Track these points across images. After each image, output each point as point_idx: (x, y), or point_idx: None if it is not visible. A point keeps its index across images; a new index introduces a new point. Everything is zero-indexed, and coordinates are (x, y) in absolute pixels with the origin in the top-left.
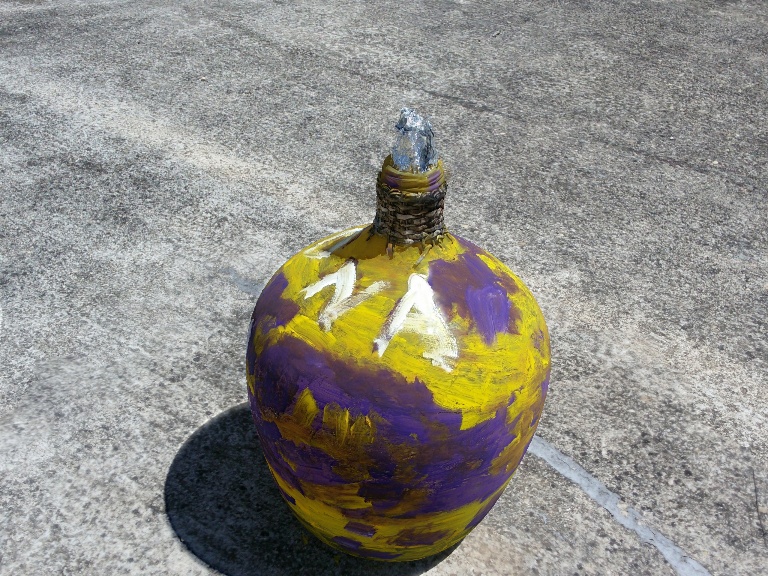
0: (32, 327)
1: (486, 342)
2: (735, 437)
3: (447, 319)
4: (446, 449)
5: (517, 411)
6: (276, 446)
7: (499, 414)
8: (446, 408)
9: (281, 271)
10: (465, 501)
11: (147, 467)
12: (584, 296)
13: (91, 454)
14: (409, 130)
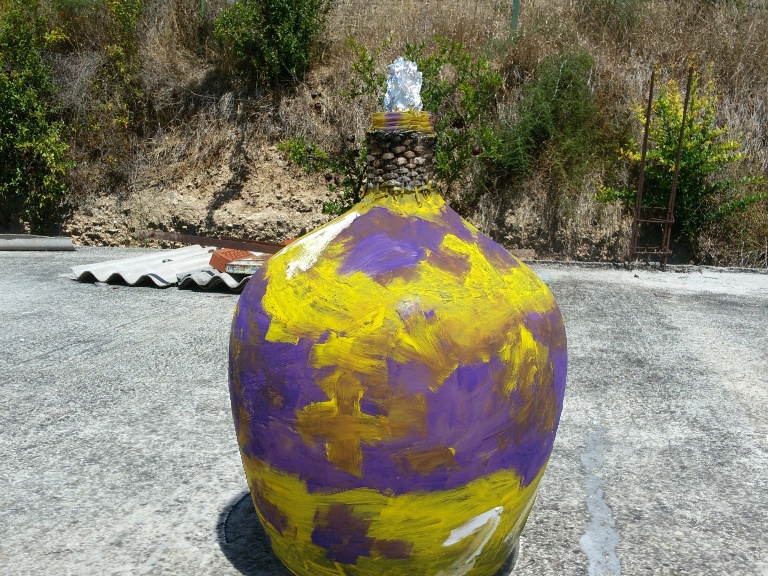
0: None
1: (338, 270)
2: None
3: (331, 244)
4: None
5: (328, 358)
6: None
7: (304, 344)
8: None
9: None
10: (285, 466)
11: None
12: None
13: None
14: None
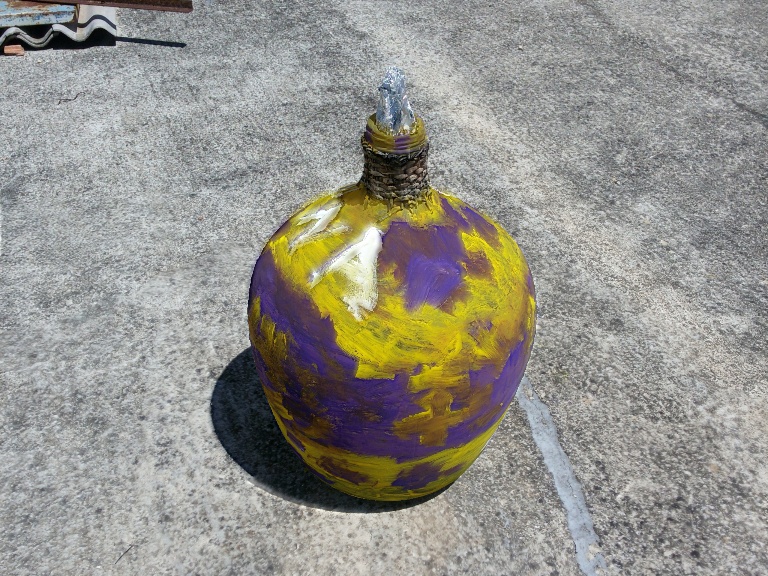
0: (234, 214)
1: (408, 308)
2: None
3: (380, 276)
4: (342, 390)
5: (424, 384)
6: None
7: (400, 379)
8: (345, 352)
9: None
10: (375, 452)
11: (230, 343)
12: (737, 349)
13: (202, 319)
14: (389, 93)
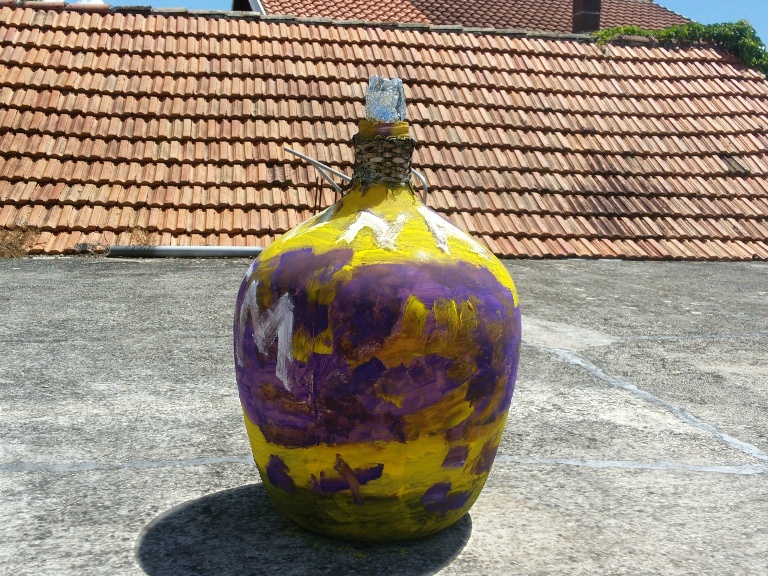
0: None
1: None
2: (512, 416)
3: None
4: (512, 327)
5: None
6: (375, 389)
7: None
8: (504, 287)
9: (277, 256)
10: None
11: None
12: None
13: None
14: (386, 90)
